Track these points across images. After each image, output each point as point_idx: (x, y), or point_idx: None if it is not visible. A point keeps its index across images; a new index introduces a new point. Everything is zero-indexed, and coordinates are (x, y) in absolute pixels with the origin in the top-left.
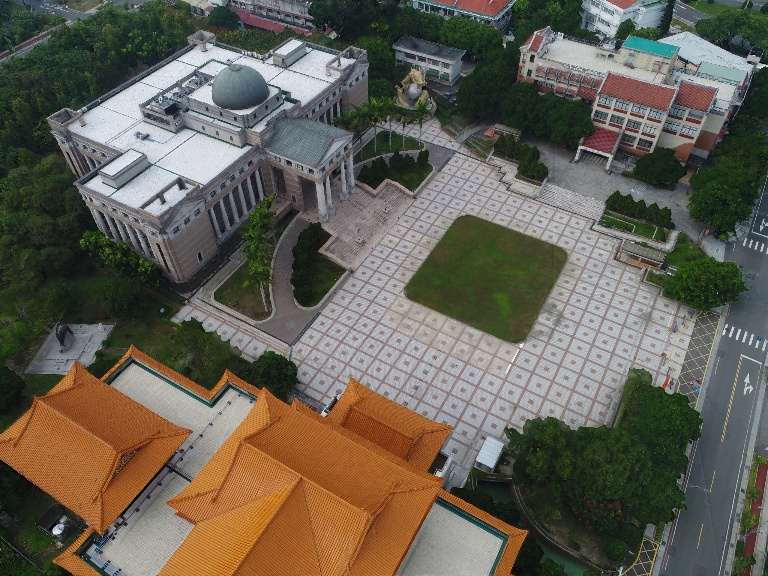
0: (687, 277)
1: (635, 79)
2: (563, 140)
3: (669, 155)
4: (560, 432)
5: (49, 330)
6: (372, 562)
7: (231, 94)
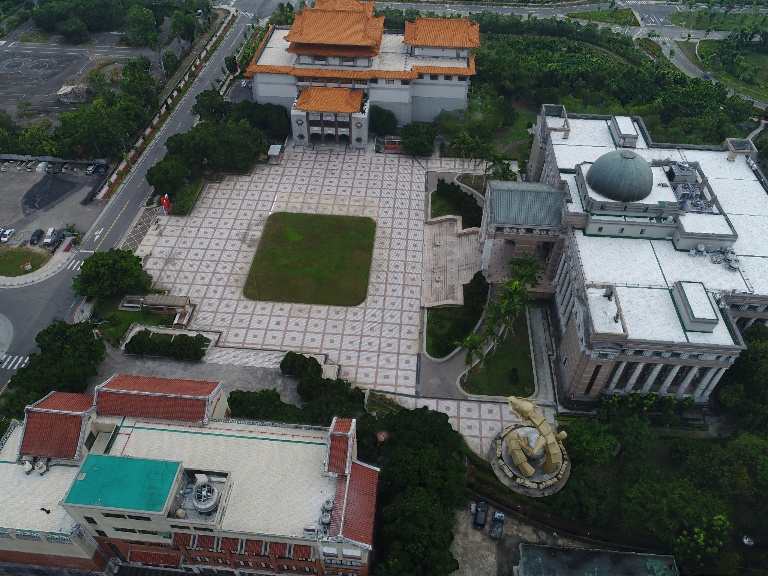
0: (132, 256)
1: (164, 394)
2: None
3: None
4: None
5: None
6: None
7: None
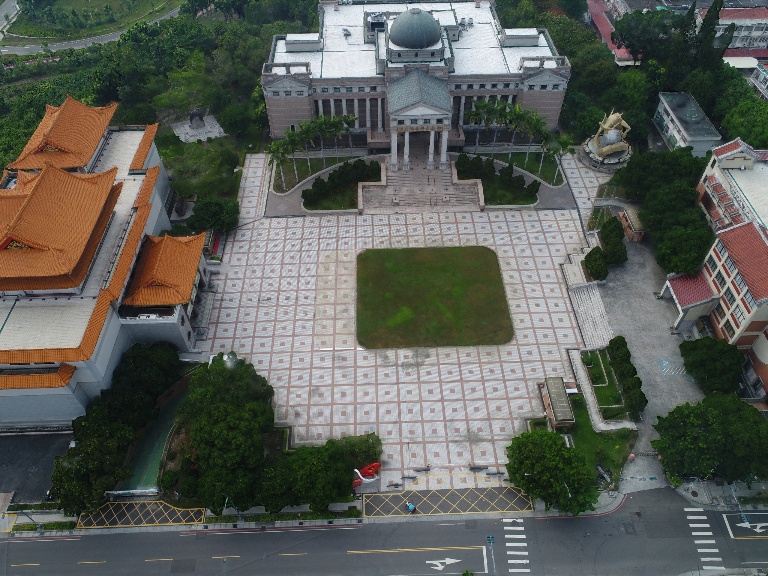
0: (526, 436)
1: None
2: (661, 264)
3: (730, 357)
4: (235, 380)
5: (206, 115)
6: (2, 262)
7: (395, 28)
